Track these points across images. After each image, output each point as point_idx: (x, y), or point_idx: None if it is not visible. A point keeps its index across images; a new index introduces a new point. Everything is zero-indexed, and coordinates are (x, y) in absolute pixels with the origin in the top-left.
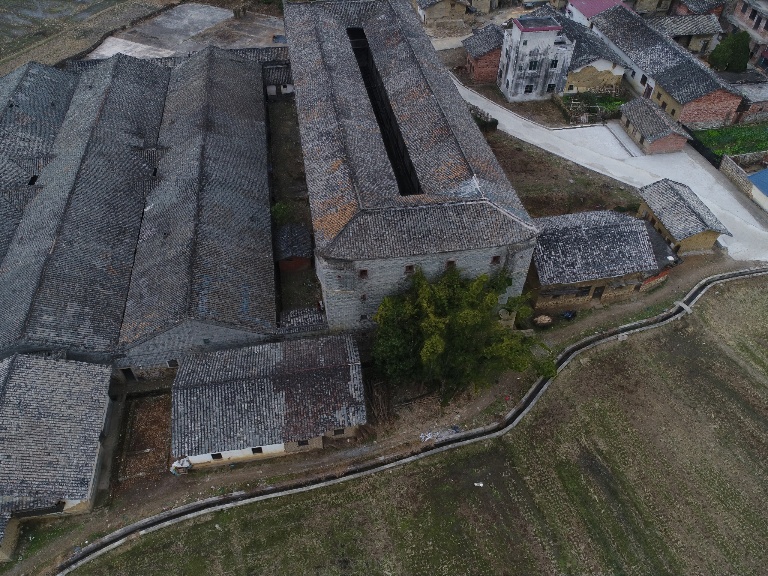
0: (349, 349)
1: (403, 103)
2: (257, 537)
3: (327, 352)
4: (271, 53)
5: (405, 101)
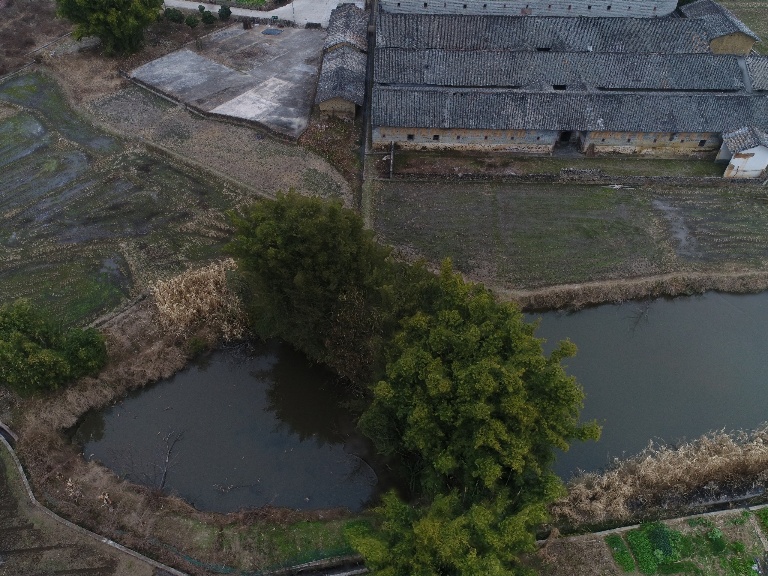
0: (695, 3)
1: None
2: (767, 52)
3: (698, 7)
4: (354, 14)
5: None
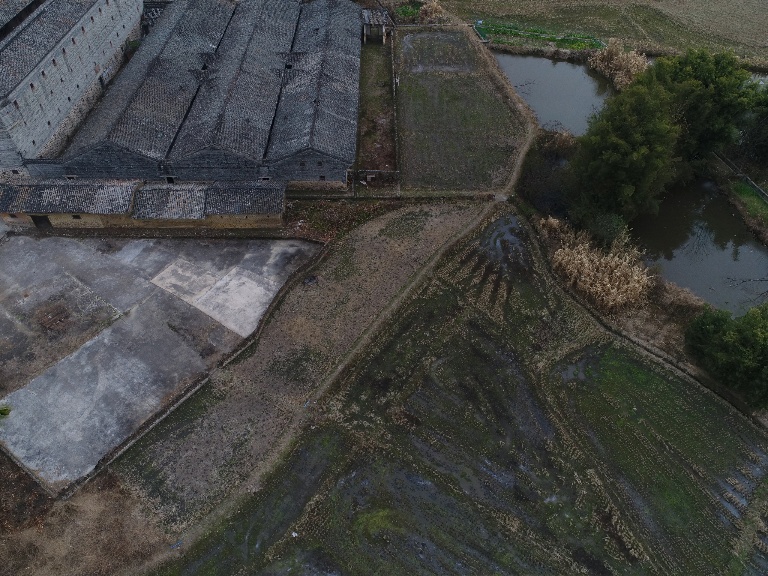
0: None
1: (14, 5)
2: None
3: None
4: None
5: (11, 5)
